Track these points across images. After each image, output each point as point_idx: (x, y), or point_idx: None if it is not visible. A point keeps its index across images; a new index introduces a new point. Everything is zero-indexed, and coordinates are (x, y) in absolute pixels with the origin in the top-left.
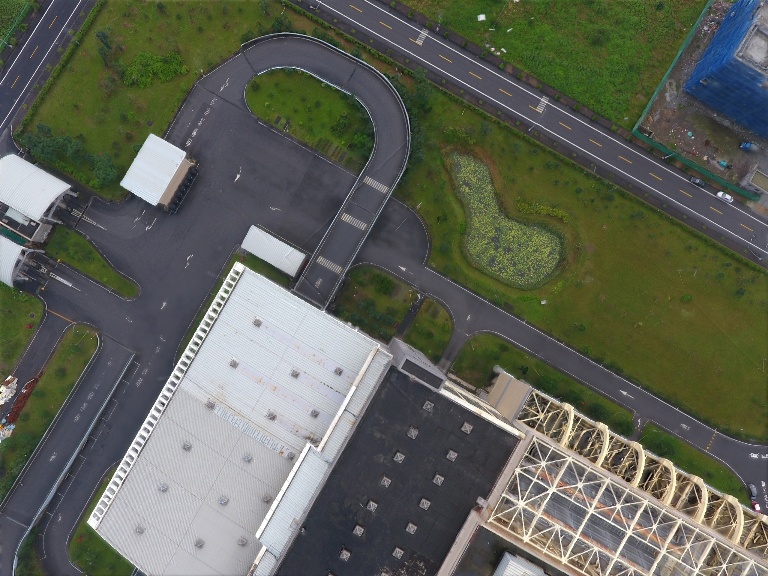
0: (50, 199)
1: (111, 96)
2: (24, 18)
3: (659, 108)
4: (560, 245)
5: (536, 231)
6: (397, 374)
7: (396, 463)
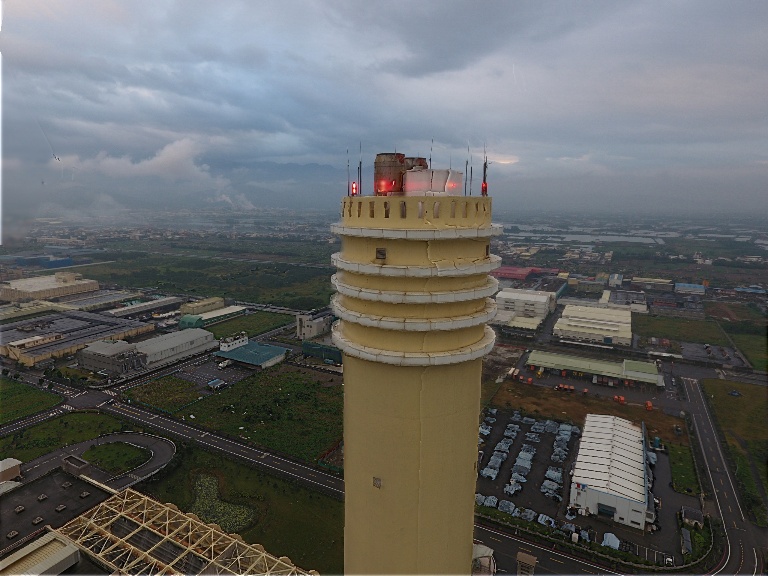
0: None
1: (1, 453)
2: None
3: (336, 455)
4: (254, 513)
5: (239, 507)
6: (60, 473)
7: (14, 514)
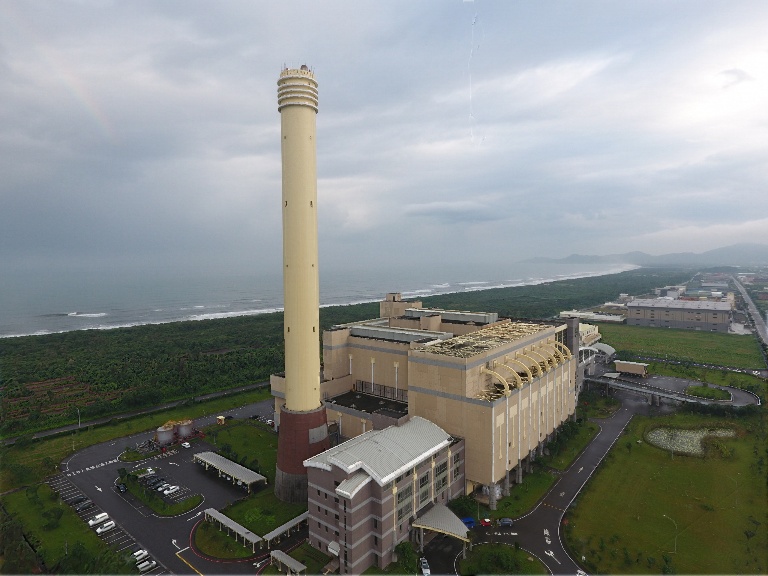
0: (601, 349)
1: None
2: (683, 361)
3: None
4: None
5: None
6: None
7: None
